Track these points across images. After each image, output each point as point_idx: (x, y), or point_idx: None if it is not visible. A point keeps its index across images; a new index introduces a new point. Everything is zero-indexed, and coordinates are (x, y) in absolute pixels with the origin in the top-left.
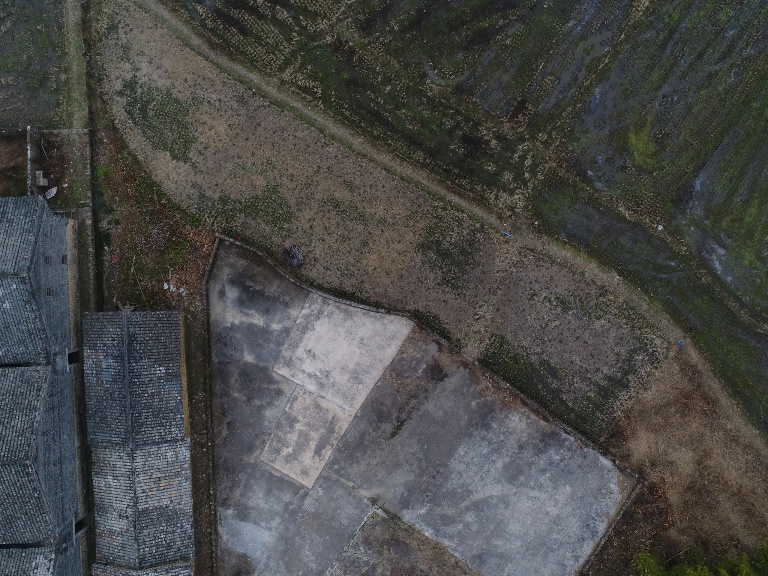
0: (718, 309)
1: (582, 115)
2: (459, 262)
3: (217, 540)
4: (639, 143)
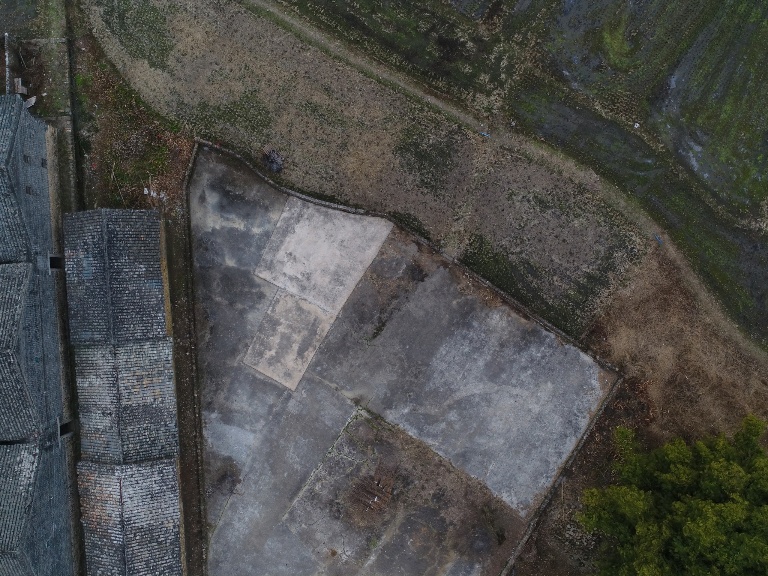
0: (695, 205)
1: (557, 16)
2: (437, 164)
3: (202, 443)
4: (614, 42)
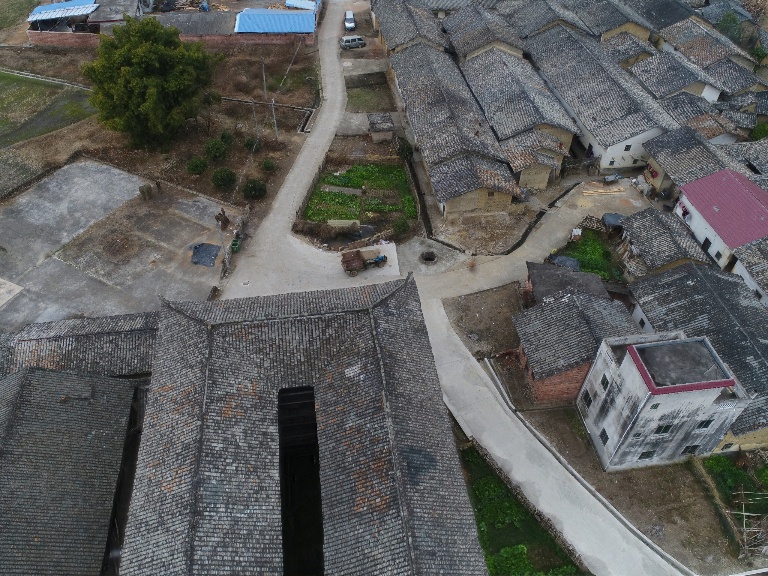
0: None
1: None
2: None
3: None
4: None
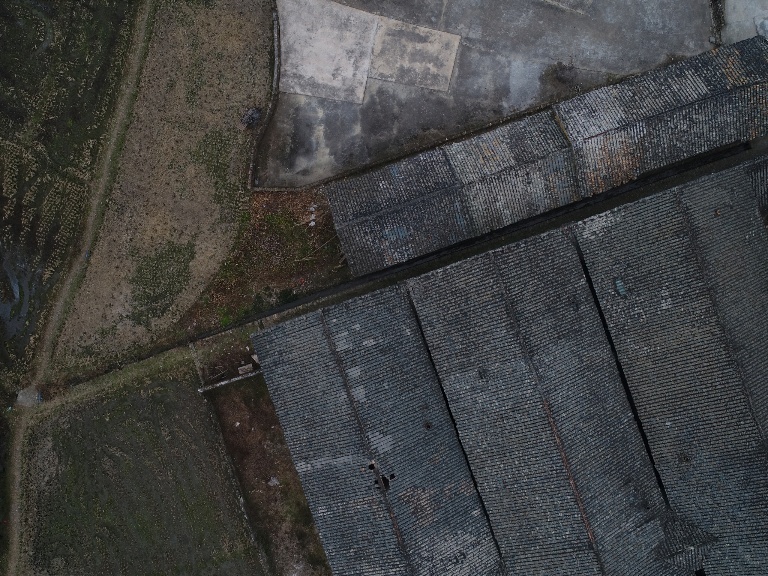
0: None
1: None
2: None
3: None
4: None
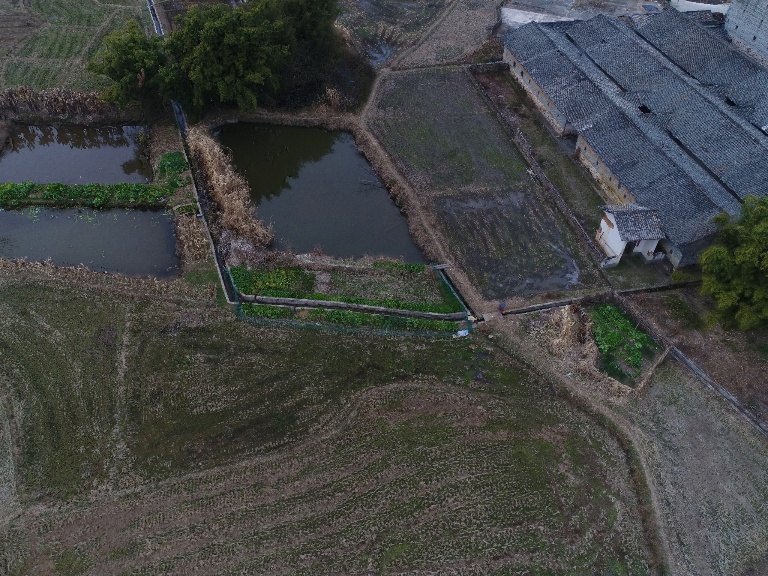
0: None
1: None
2: None
3: None
4: None
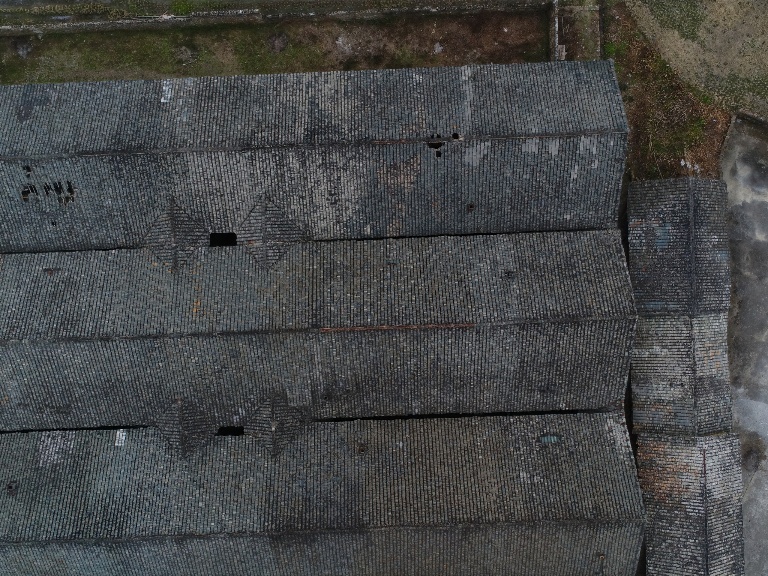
0: None
1: None
2: None
3: None
4: None
